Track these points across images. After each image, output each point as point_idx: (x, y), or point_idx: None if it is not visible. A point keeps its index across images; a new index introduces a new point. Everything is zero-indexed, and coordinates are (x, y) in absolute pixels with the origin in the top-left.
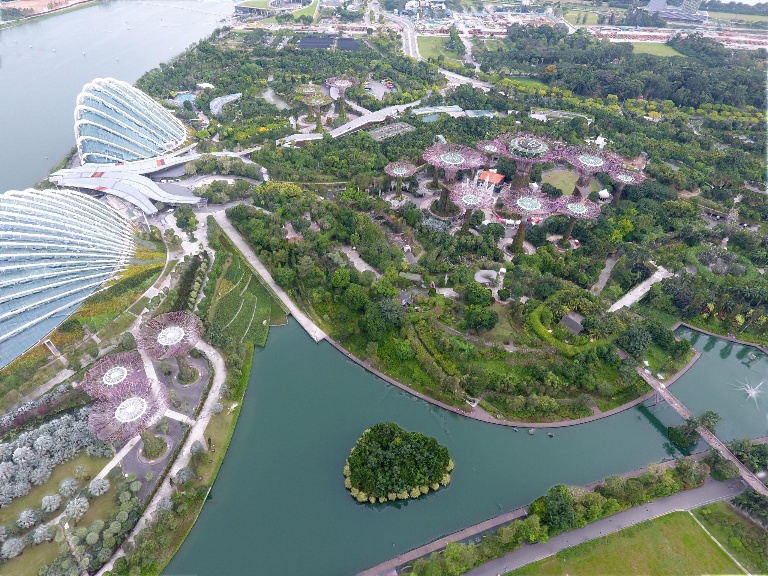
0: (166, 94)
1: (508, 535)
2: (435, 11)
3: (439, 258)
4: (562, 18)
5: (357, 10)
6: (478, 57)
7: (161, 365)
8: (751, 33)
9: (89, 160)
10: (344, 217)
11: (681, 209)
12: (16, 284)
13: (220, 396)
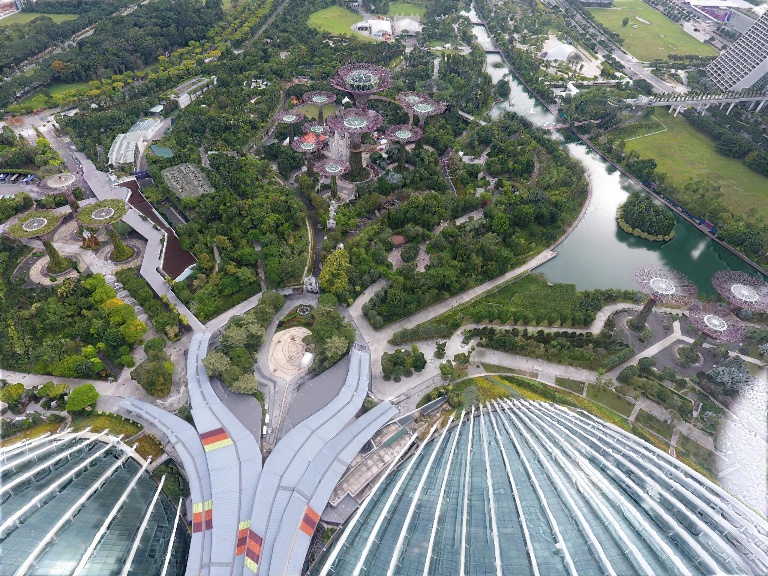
0: None
1: None
2: None
3: None
4: None
5: None
6: None
7: None
8: None
9: None
10: None
11: None
12: None
13: (641, 304)
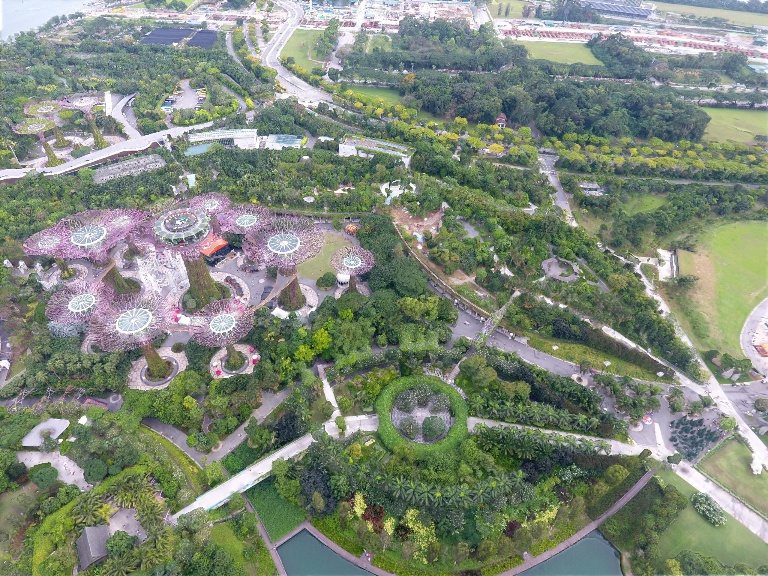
0: None
1: None
2: None
3: None
4: (485, 8)
5: None
6: (343, 59)
7: None
8: (698, 32)
9: None
10: None
11: (416, 312)
12: None
13: None
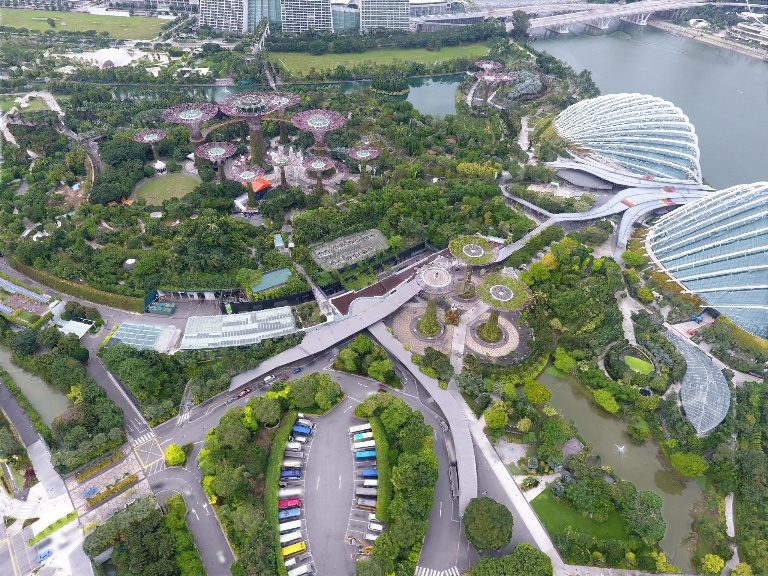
0: None
1: (360, 67)
2: None
3: None
4: None
5: None
6: None
7: None
8: None
9: None
10: None
11: None
12: None
13: None
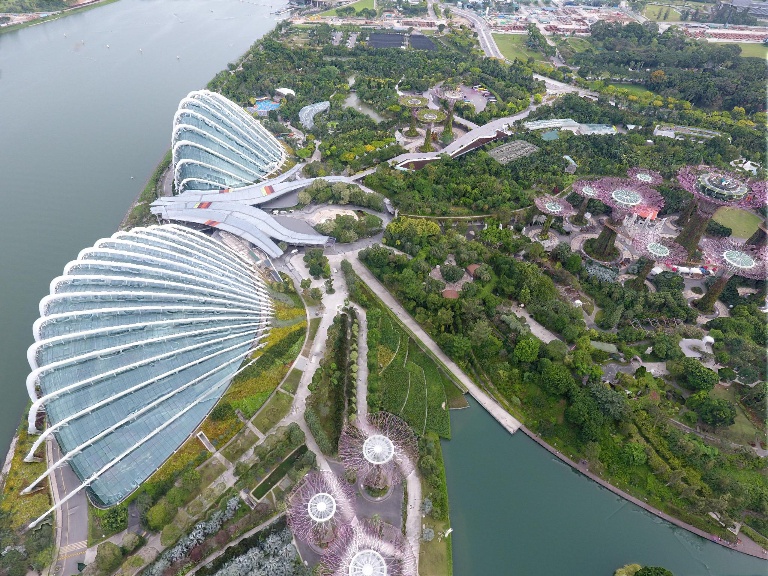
0: (245, 101)
1: None
2: (501, 4)
3: (622, 319)
4: (639, 13)
5: (418, 2)
6: (568, 59)
7: (349, 474)
8: None
9: (189, 186)
10: (506, 267)
11: None
12: (158, 361)
13: (422, 514)
